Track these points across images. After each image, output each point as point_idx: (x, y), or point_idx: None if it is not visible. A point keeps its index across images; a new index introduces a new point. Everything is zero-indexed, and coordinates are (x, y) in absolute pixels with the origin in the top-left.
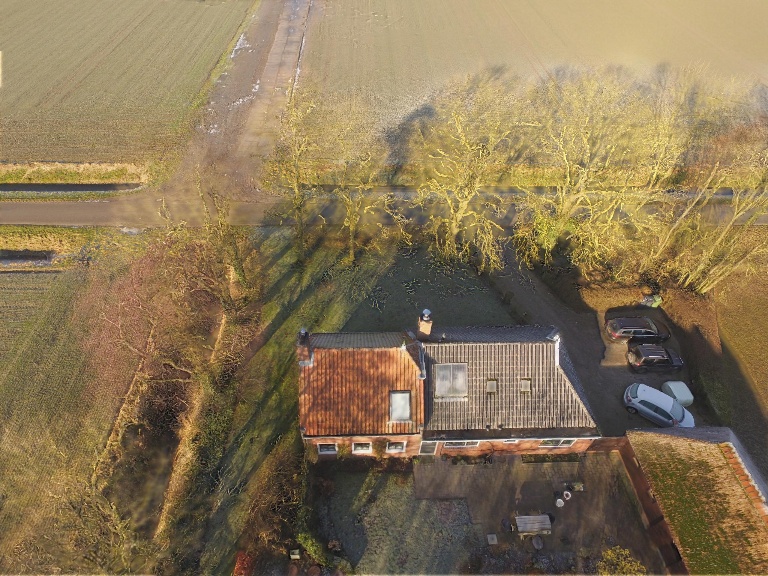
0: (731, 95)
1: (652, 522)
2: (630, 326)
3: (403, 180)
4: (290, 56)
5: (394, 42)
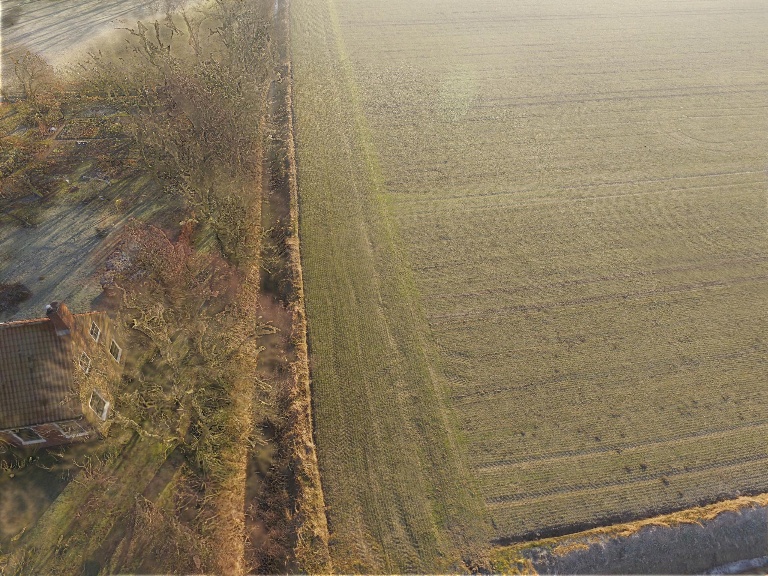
0: None
1: None
2: None
3: None
4: None
5: None
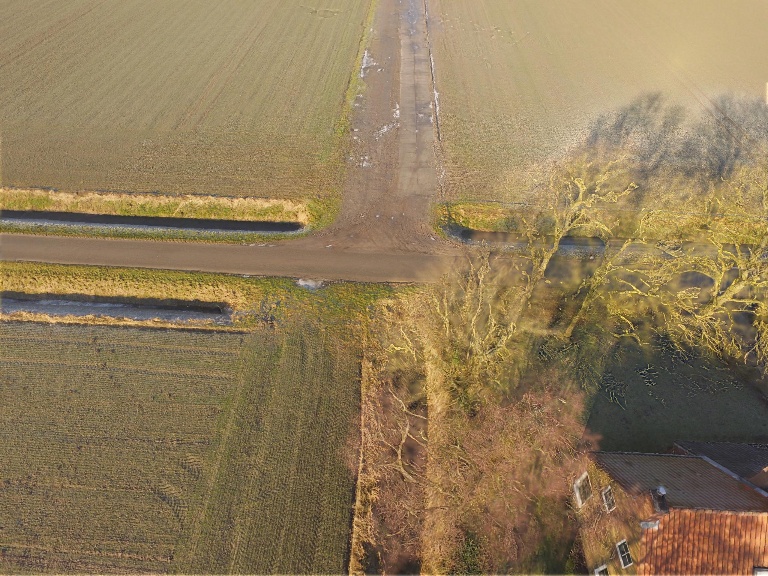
0: None
1: None
2: None
3: (586, 230)
4: (423, 77)
5: (528, 62)
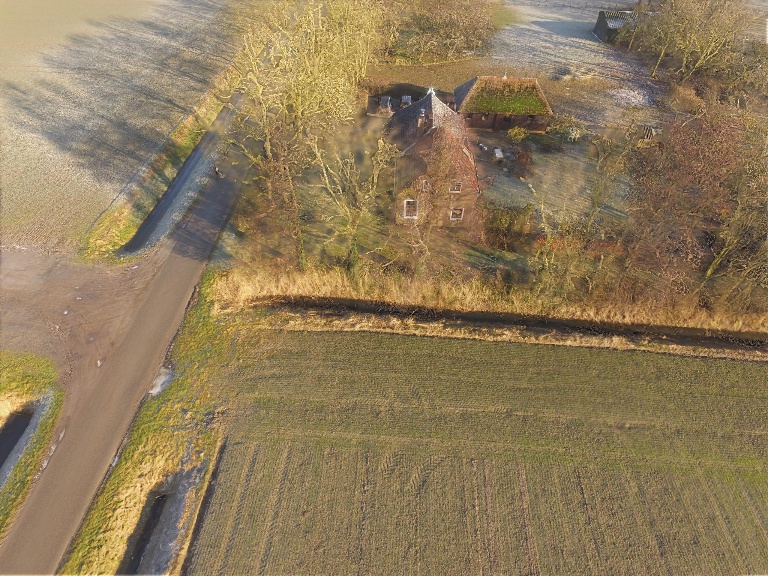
0: (159, 17)
1: (493, 126)
2: (387, 101)
3: (169, 174)
4: None
5: None
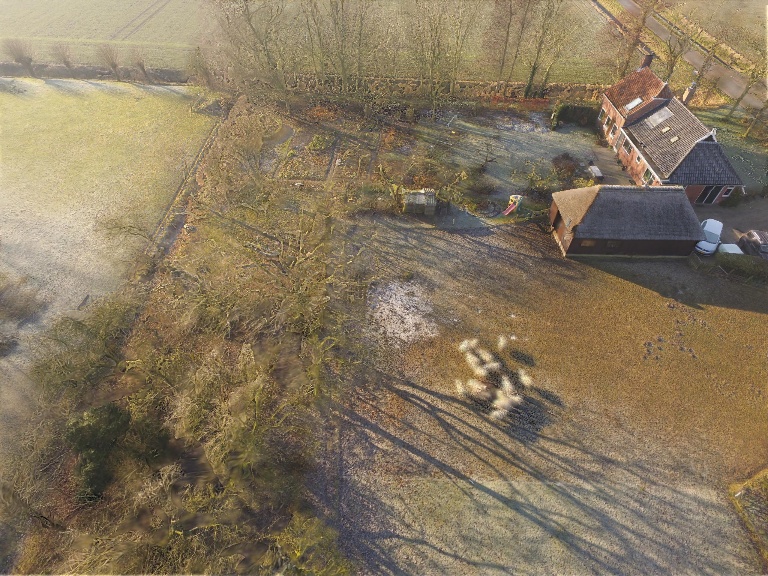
0: None
1: None
2: None
3: None
4: None
5: None
